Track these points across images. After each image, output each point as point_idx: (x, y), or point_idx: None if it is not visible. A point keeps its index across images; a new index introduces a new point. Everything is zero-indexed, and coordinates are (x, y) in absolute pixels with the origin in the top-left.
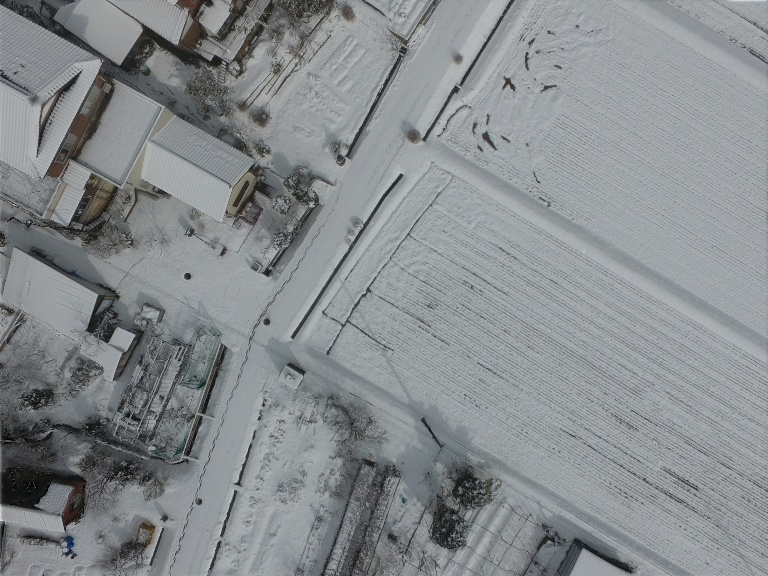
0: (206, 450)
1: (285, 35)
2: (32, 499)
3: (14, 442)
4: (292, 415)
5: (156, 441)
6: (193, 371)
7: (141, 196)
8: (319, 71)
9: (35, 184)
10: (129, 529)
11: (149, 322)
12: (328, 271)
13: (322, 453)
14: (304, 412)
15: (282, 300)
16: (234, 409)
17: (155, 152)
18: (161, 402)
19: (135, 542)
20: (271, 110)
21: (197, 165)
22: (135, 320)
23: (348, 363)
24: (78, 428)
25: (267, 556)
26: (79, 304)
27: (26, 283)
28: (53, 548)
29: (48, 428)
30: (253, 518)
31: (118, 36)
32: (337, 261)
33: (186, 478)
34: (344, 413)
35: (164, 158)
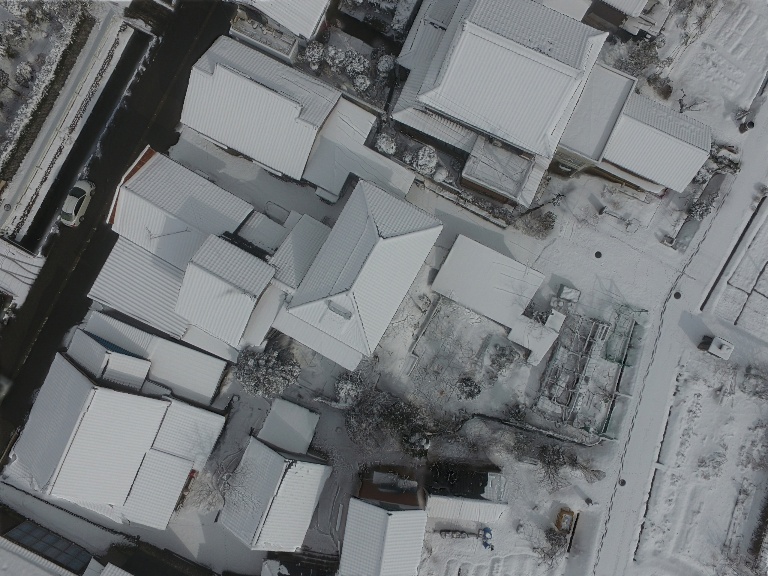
0: (625, 430)
1: (694, 6)
2: (470, 489)
3: (434, 434)
4: (711, 388)
5: (575, 424)
6: (607, 350)
7: (551, 177)
8: (713, 41)
9: (506, 166)
10: (547, 516)
11: (564, 303)
12: (735, 240)
13: (741, 425)
14: (725, 384)
15: (691, 272)
16: (651, 386)
17: (625, 126)
18: (586, 383)
19: (560, 528)
20: (670, 83)
21: (672, 135)
22: (551, 302)
23: (758, 332)
24: (493, 416)
25: (692, 534)
26: (521, 287)
27: (465, 270)
28: (471, 540)
29: (471, 417)
30: (674, 496)
31: (568, 15)
32: (742, 229)
33: (606, 460)
34: (765, 382)
35: (634, 131)
